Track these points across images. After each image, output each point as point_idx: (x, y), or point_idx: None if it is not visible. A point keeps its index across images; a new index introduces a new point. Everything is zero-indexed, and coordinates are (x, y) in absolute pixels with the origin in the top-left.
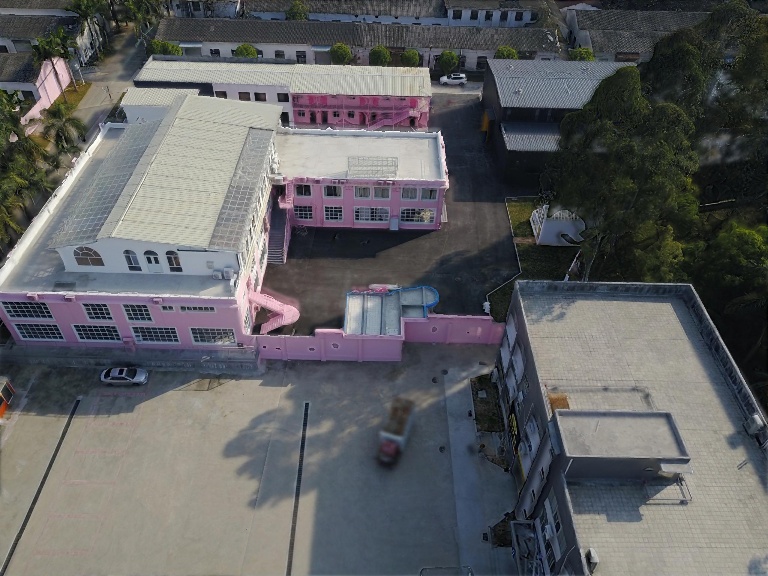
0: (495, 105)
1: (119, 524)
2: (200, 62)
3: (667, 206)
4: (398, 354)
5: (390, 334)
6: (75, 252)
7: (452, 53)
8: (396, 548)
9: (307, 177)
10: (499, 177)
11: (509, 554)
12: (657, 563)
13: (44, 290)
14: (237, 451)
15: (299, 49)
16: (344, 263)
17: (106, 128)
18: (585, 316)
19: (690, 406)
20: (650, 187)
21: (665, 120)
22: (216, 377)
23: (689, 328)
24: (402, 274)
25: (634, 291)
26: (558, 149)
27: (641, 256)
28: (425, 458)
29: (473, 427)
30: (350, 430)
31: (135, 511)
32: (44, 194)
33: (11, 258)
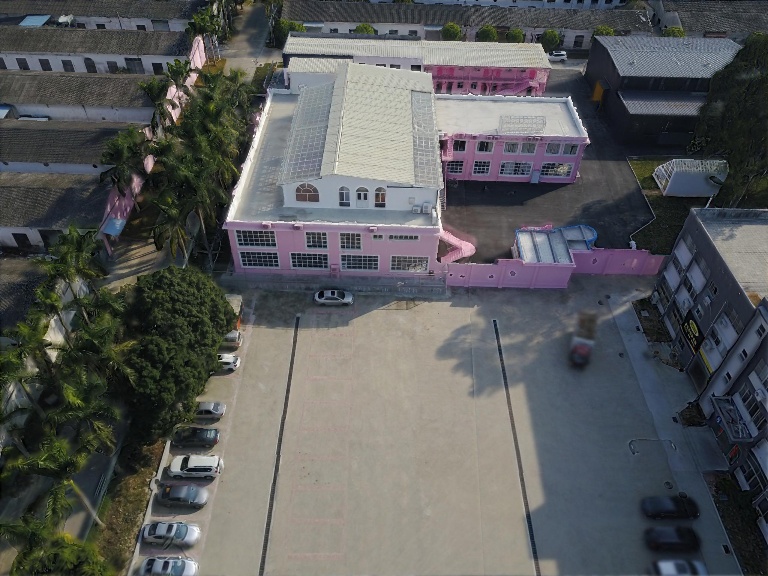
0: (608, 76)
1: (365, 408)
2: (333, 38)
3: None
4: (566, 281)
5: (563, 262)
6: (298, 189)
7: (554, 32)
8: (602, 427)
9: (465, 133)
10: (617, 139)
11: (700, 431)
12: None
13: (272, 221)
14: (447, 356)
15: (412, 29)
16: (497, 210)
17: (272, 93)
18: (754, 237)
19: None
20: None
21: None
22: (411, 300)
23: None
24: (551, 219)
25: None
26: (674, 113)
27: None
28: (608, 362)
29: (643, 339)
30: (538, 341)
31: (375, 399)
32: (247, 145)
33: (236, 195)
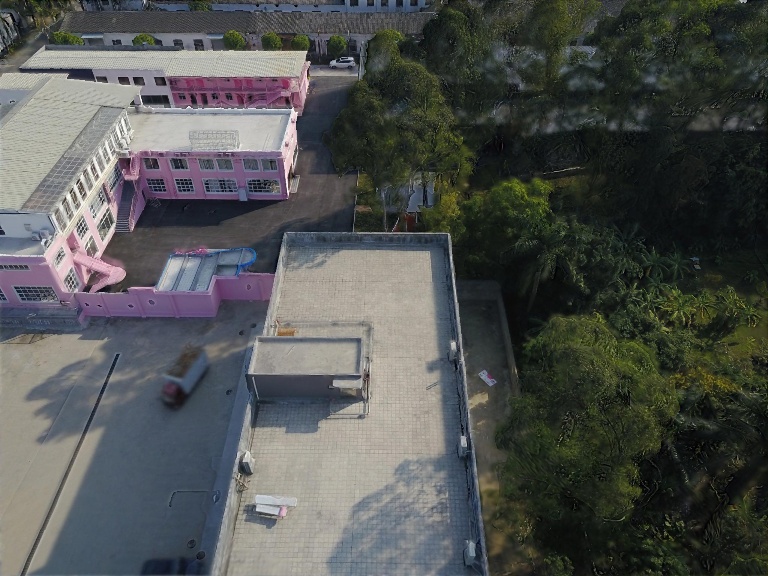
0: None
1: None
2: (90, 51)
3: (415, 159)
4: (211, 310)
5: (199, 290)
6: None
7: (340, 37)
8: (160, 476)
9: (151, 150)
10: None
11: None
12: (314, 466)
13: None
14: (40, 395)
15: (196, 38)
16: (187, 231)
17: None
18: (344, 263)
19: (406, 338)
20: (400, 142)
21: (406, 78)
22: (40, 332)
23: (437, 272)
24: (239, 240)
25: (398, 241)
26: None
27: (424, 212)
28: (211, 400)
29: None
30: (150, 377)
31: None
32: None
33: None
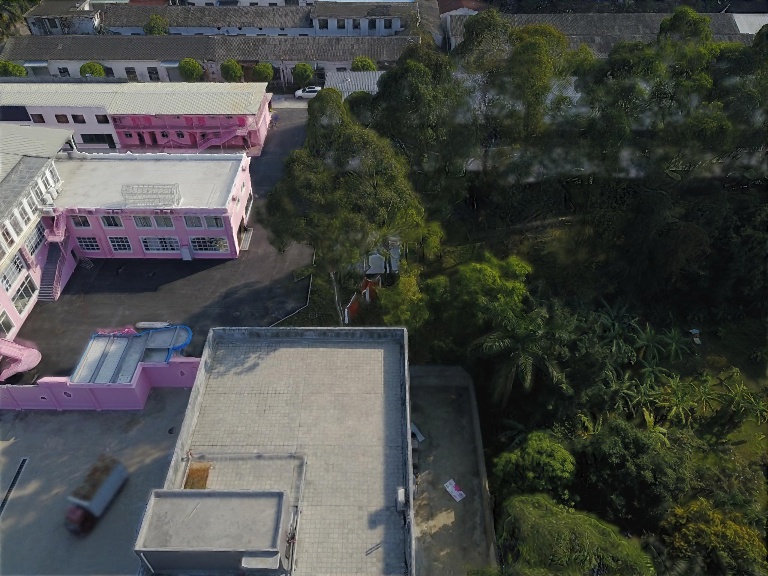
0: None
1: None
2: (27, 83)
3: (363, 244)
4: (137, 402)
5: (121, 382)
6: None
7: (306, 65)
8: None
9: (78, 208)
10: None
11: None
12: None
13: None
14: None
15: (149, 65)
16: (120, 298)
17: None
18: (279, 367)
19: (346, 476)
20: (345, 223)
21: (350, 149)
22: None
23: (390, 379)
24: (178, 310)
25: (346, 336)
26: None
27: (380, 293)
28: (127, 523)
29: None
30: (59, 490)
31: None
32: None
33: None
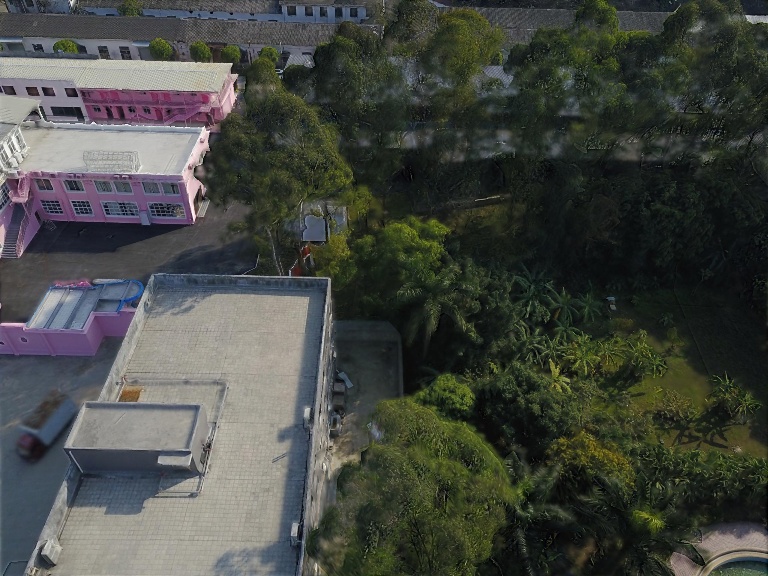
0: None
1: None
2: (0, 57)
3: (290, 199)
4: (89, 348)
5: (73, 328)
6: None
7: (272, 49)
8: (1, 542)
9: (42, 171)
10: None
11: None
12: (127, 556)
13: None
14: None
15: (121, 45)
16: (80, 258)
17: None
18: (213, 309)
19: (263, 399)
20: (275, 180)
21: (279, 112)
22: None
23: (312, 322)
24: (134, 269)
25: (276, 285)
26: None
27: None
28: None
29: None
30: (12, 424)
31: None
32: None
33: None
